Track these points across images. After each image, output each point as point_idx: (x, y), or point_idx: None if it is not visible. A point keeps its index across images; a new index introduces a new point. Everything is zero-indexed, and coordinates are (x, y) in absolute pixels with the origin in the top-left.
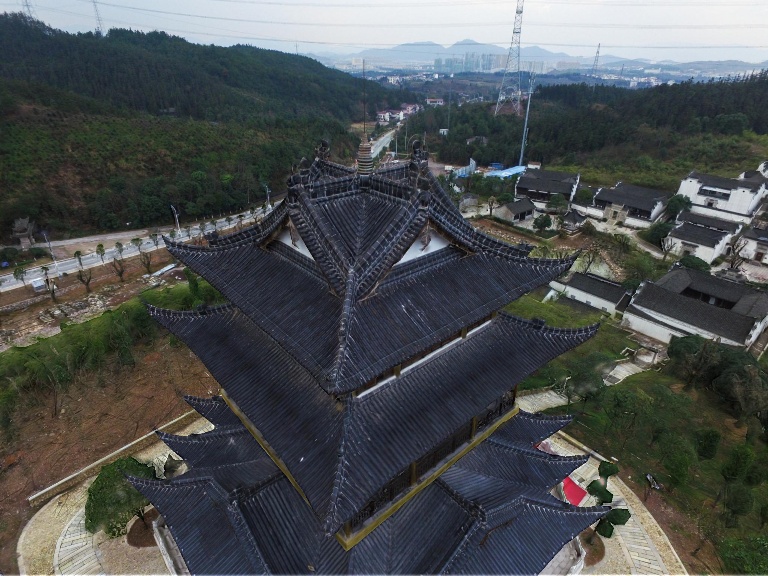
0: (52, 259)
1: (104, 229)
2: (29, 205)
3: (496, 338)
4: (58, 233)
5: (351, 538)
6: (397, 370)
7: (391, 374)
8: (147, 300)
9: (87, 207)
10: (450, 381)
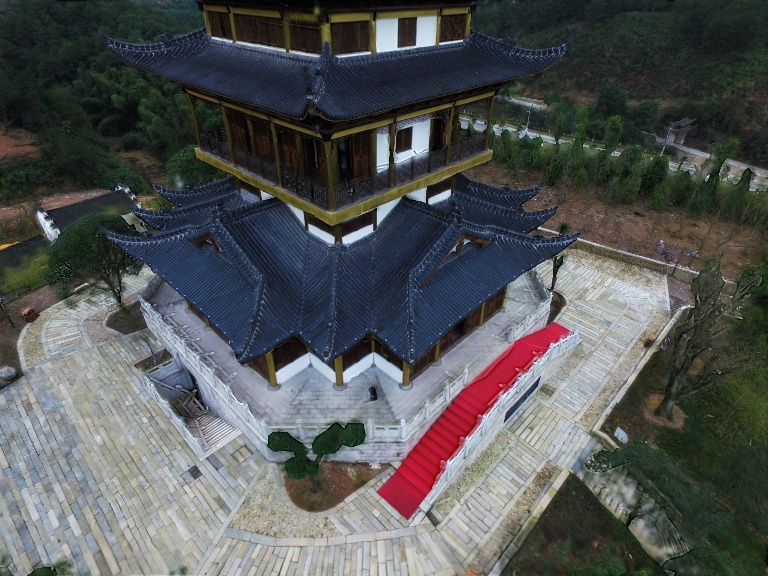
0: (672, 159)
1: (750, 158)
2: (707, 110)
3: (303, 73)
4: (707, 144)
5: (197, 149)
6: (233, 36)
7: (232, 38)
8: (560, 146)
9: (757, 131)
10: (239, 68)
